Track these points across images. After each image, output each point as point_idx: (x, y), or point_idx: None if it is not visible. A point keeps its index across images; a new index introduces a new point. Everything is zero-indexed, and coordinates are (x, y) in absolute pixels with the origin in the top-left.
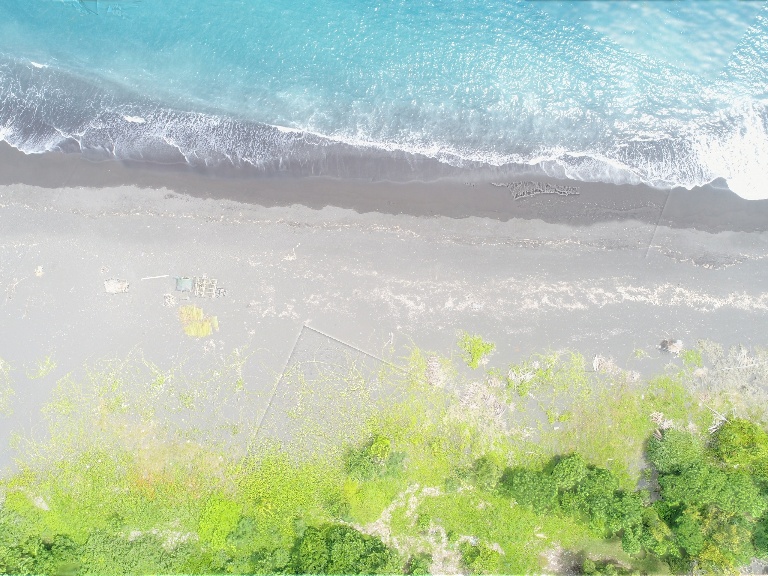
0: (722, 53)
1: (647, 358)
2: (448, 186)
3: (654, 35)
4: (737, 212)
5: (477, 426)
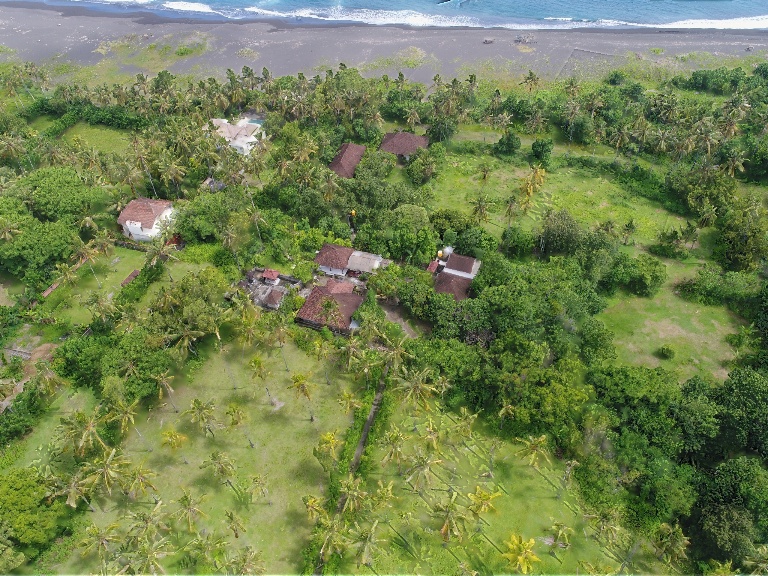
0: (729, 3)
1: (740, 52)
2: (626, 30)
3: (698, 2)
4: (760, 33)
5: (667, 69)
